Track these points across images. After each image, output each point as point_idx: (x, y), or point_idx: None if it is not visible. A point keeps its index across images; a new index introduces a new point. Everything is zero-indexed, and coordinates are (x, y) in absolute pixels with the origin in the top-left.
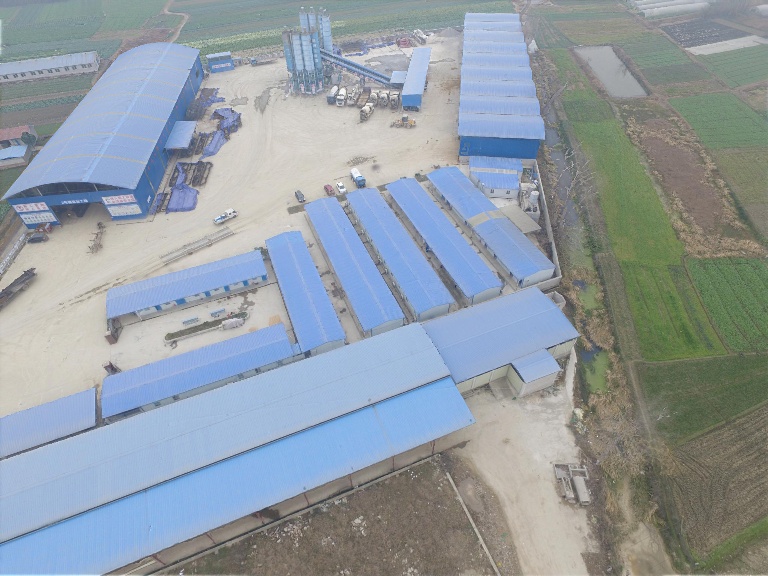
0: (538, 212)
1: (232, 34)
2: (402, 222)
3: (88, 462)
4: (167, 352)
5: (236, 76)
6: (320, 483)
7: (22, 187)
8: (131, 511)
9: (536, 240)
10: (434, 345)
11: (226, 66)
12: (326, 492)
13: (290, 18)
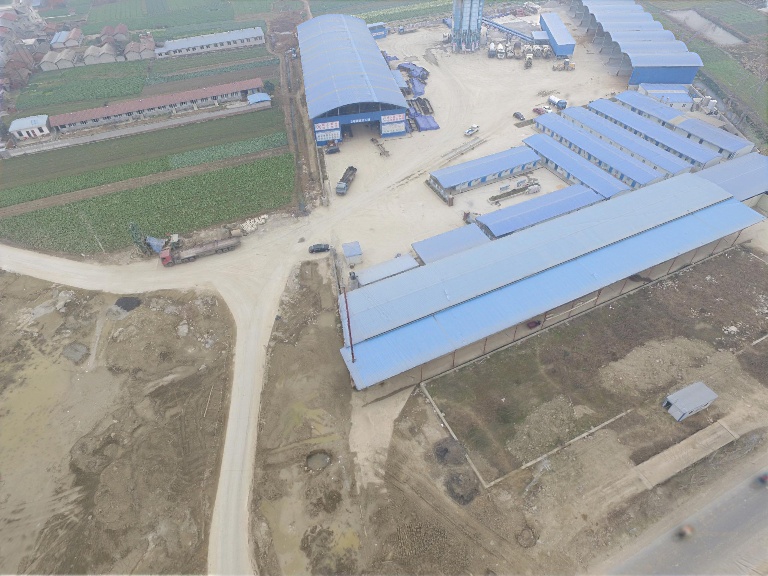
0: (719, 114)
1: (361, 12)
2: None
3: (526, 247)
4: (496, 208)
5: (392, 42)
6: (687, 250)
7: (325, 108)
8: (574, 269)
9: None
10: (711, 182)
11: (380, 34)
12: (674, 268)
13: None
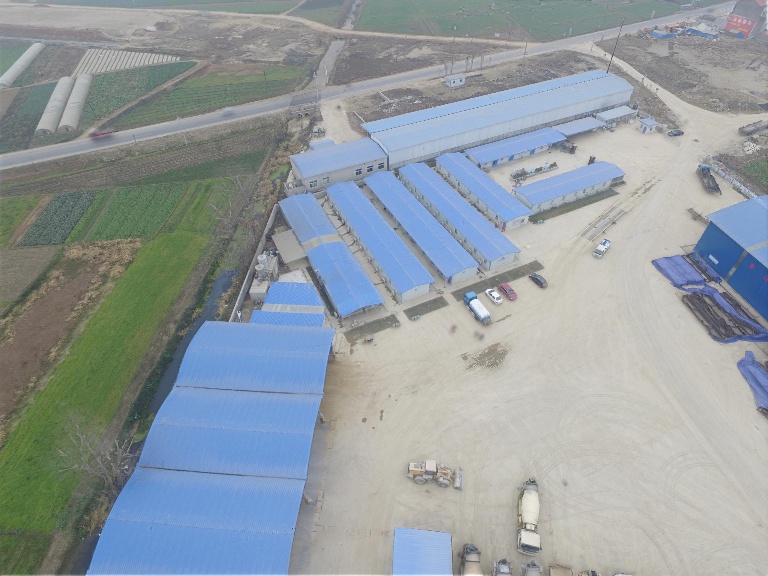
0: None
1: None
2: None
3: None
4: (549, 161)
5: None
6: None
7: None
8: None
9: None
10: None
11: None
12: None
13: None
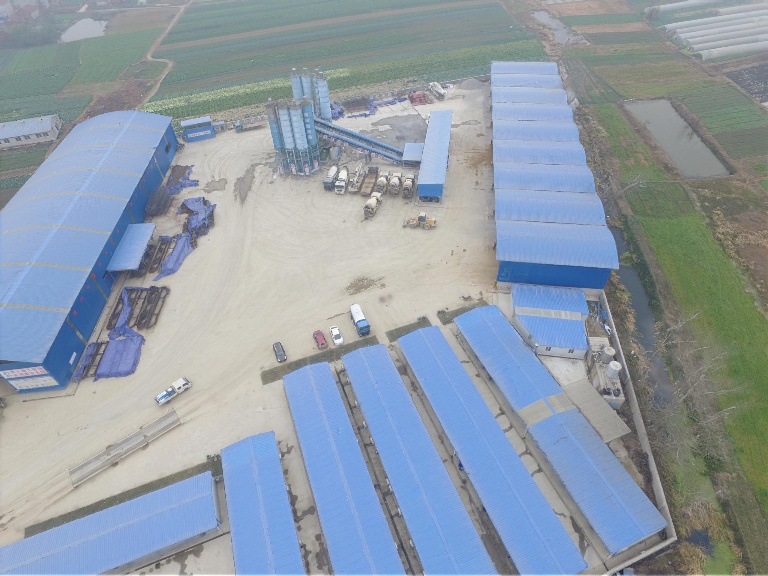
0: (621, 397)
1: (218, 87)
2: (421, 403)
3: None
4: None
5: (216, 147)
6: None
7: None
8: None
9: (622, 444)
10: None
11: (205, 134)
12: None
13: (286, 65)
